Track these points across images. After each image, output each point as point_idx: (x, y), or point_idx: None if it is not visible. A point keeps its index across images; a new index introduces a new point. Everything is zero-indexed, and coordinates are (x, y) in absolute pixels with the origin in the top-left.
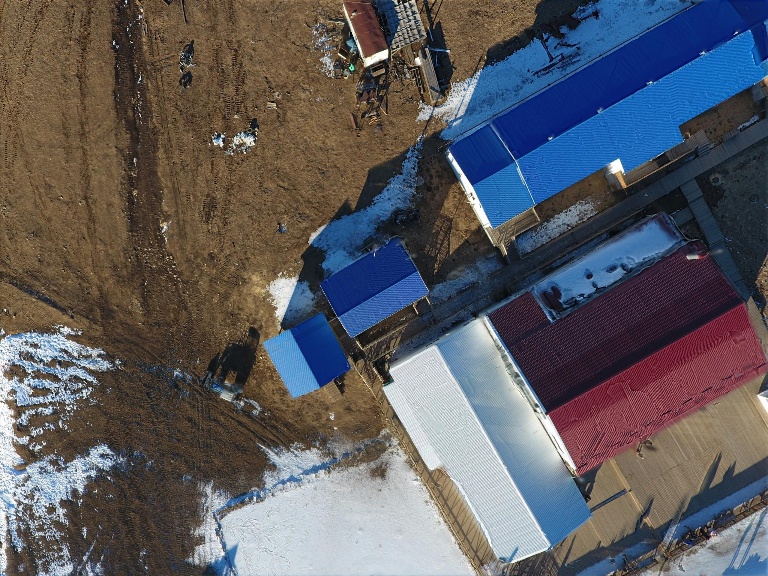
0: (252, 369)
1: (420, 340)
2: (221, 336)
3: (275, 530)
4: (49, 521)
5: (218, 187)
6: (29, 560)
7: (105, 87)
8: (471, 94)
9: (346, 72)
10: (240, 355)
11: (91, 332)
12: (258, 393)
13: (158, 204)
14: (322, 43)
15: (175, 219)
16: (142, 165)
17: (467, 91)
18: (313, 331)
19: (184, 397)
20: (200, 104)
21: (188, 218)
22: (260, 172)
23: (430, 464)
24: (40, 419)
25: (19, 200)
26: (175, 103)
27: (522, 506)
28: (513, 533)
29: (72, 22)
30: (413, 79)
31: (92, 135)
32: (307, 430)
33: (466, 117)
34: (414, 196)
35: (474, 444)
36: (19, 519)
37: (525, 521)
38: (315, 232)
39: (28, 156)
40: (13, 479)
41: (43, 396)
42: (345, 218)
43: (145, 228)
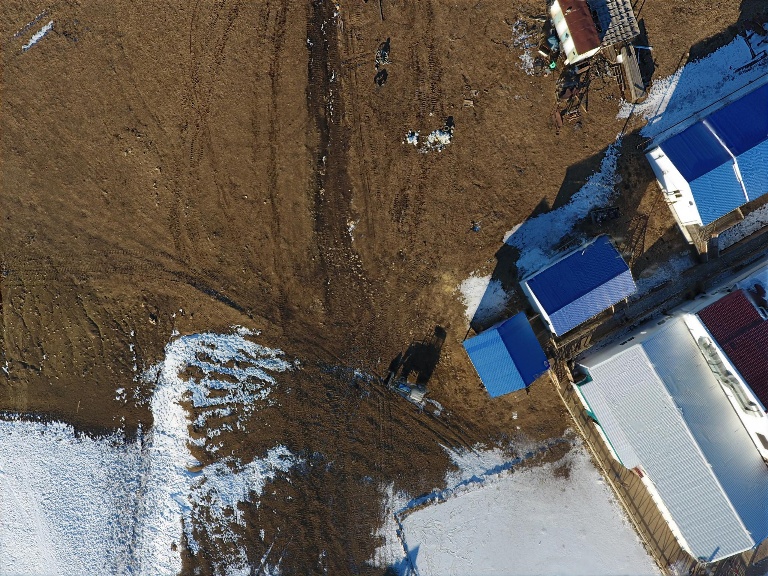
0: (435, 369)
1: (608, 339)
2: (404, 336)
3: (457, 531)
4: (226, 523)
5: (410, 185)
6: (206, 563)
7: (298, 85)
8: (672, 91)
9: (547, 69)
10: (423, 355)
11: (270, 332)
12: (440, 393)
13: (346, 203)
14: (522, 40)
15: (364, 218)
16: (331, 164)
17: (669, 88)
18: (516, 330)
19: (365, 397)
20: (394, 102)
21: (377, 217)
22: (455, 170)
23: (629, 463)
24: (217, 420)
25: (202, 199)
26: (369, 101)
27: (726, 505)
28: (715, 532)
29: (267, 20)
30: (614, 76)
31: (282, 134)
32: (489, 430)
33: (666, 114)
34: (612, 194)
35: (677, 443)
36: (195, 521)
37: (728, 520)
38: (510, 230)
39: (214, 155)
40: (188, 481)
41: (220, 397)
42: (542, 216)
43: (331, 227)
